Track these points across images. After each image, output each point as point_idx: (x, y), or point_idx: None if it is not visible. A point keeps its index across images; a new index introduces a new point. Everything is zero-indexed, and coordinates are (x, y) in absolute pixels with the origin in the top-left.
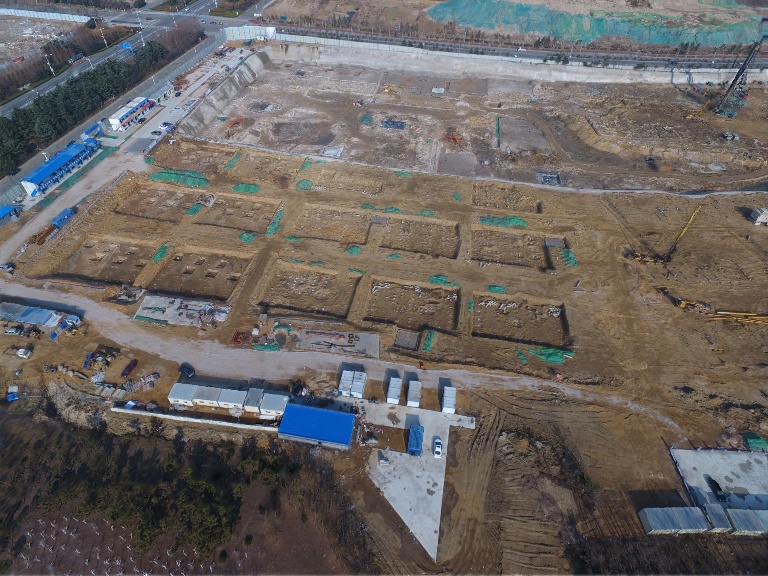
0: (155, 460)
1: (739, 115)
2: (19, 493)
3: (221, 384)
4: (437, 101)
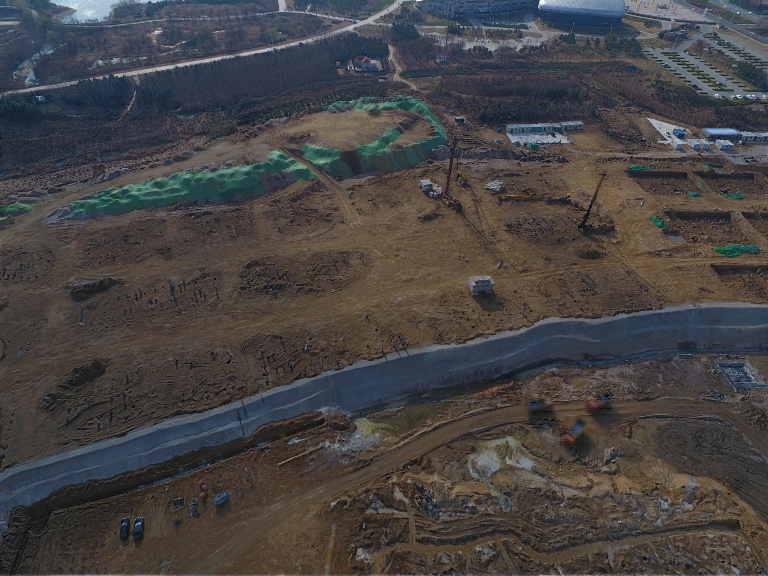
0: (765, 128)
1: None
2: None
3: None
4: None
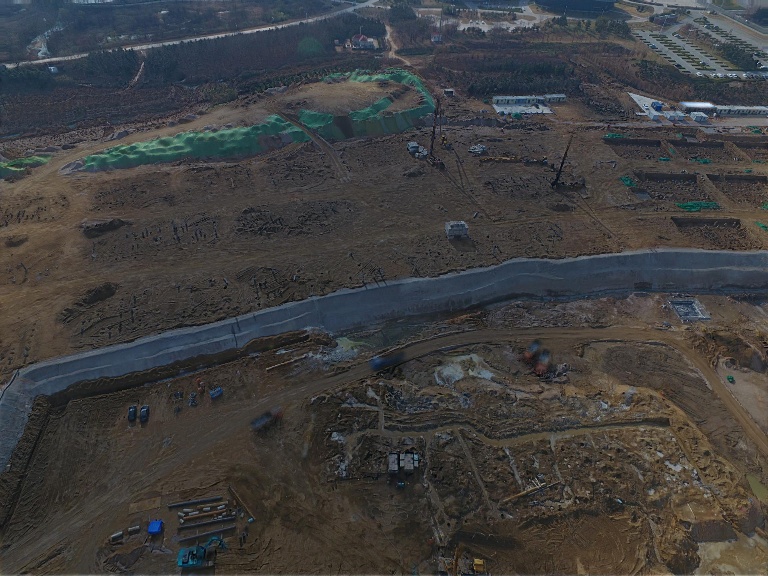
0: None
1: None
2: (767, 91)
3: (751, 116)
4: None
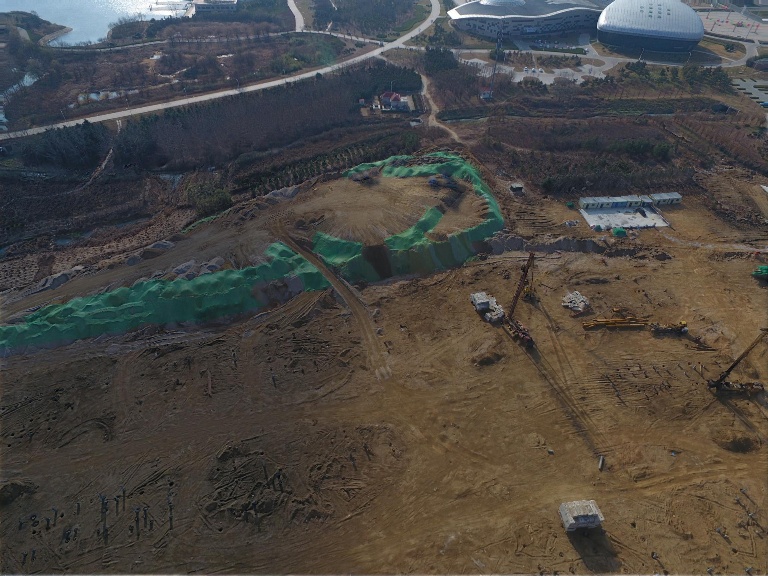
0: None
1: None
2: None
3: None
4: None
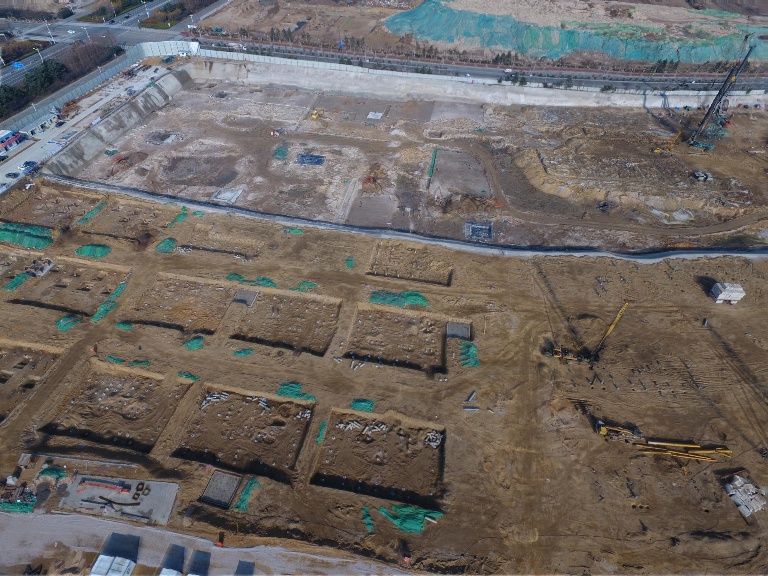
0: None
1: (717, 147)
2: None
3: None
4: (370, 129)
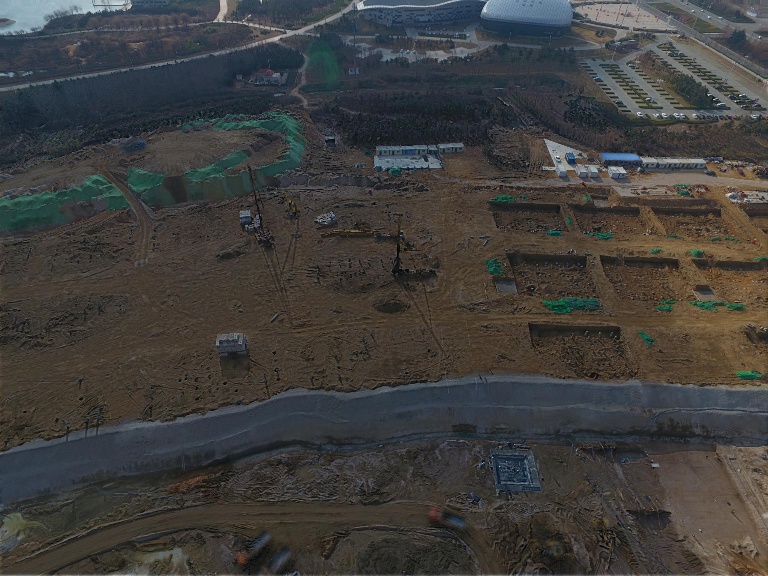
0: None
1: None
2: None
3: (685, 171)
4: None
